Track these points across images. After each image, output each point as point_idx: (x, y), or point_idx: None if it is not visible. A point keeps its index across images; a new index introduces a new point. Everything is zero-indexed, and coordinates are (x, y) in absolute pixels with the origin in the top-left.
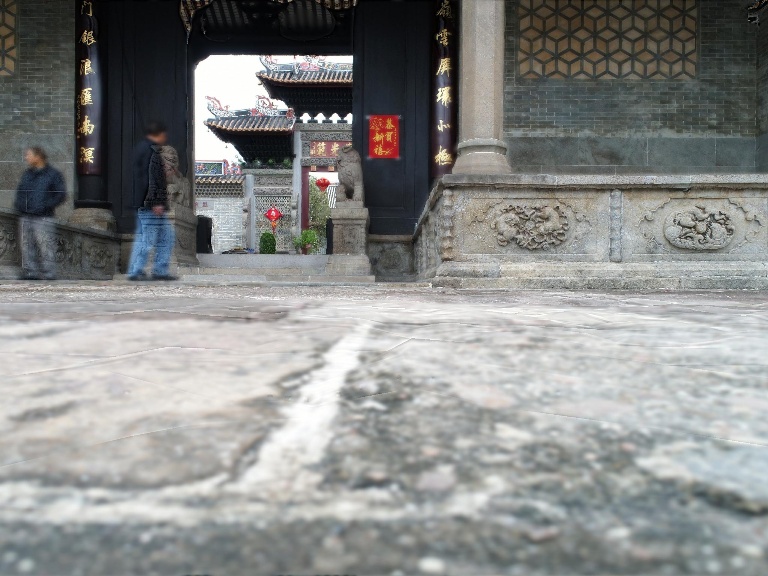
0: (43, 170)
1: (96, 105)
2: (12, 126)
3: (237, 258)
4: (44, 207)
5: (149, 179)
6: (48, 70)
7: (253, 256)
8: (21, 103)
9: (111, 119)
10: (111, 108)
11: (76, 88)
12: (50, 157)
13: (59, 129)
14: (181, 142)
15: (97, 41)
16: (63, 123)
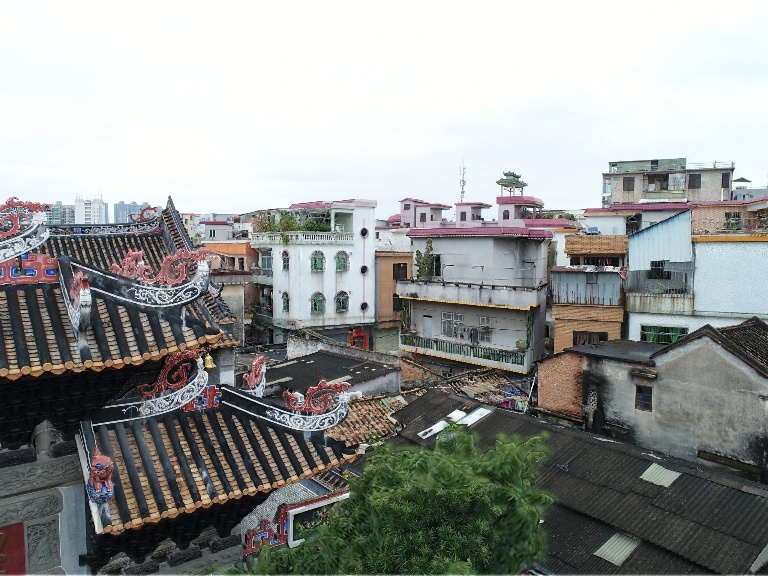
0: None
1: None
2: None
3: None
4: None
5: None
6: None
7: None
8: None
9: None
10: None
11: None
12: None
13: None
14: None
15: None
16: None
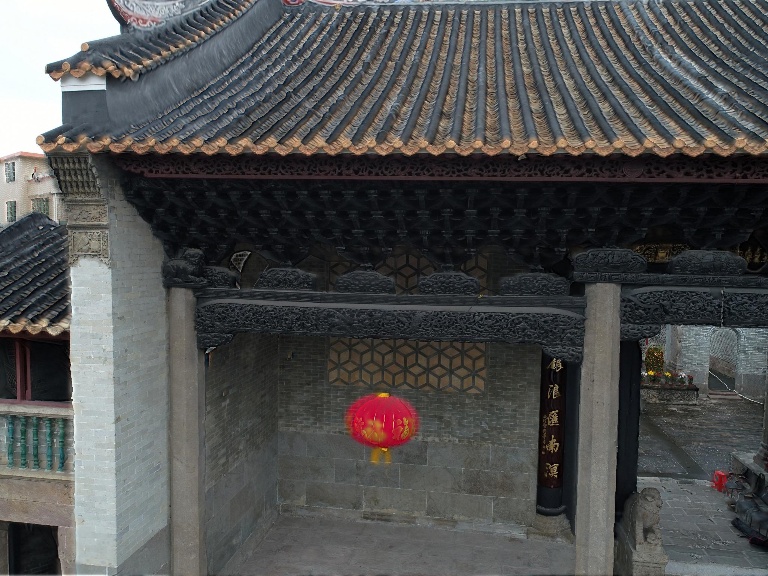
0: (508, 479)
1: (561, 424)
2: (480, 438)
3: (687, 567)
4: (509, 512)
5: (636, 520)
6: (515, 390)
7: (704, 566)
8: (489, 418)
9: (568, 431)
10: (568, 421)
11: (540, 407)
12: (515, 468)
13: (524, 443)
14: (634, 455)
15: (563, 365)
16: (528, 438)
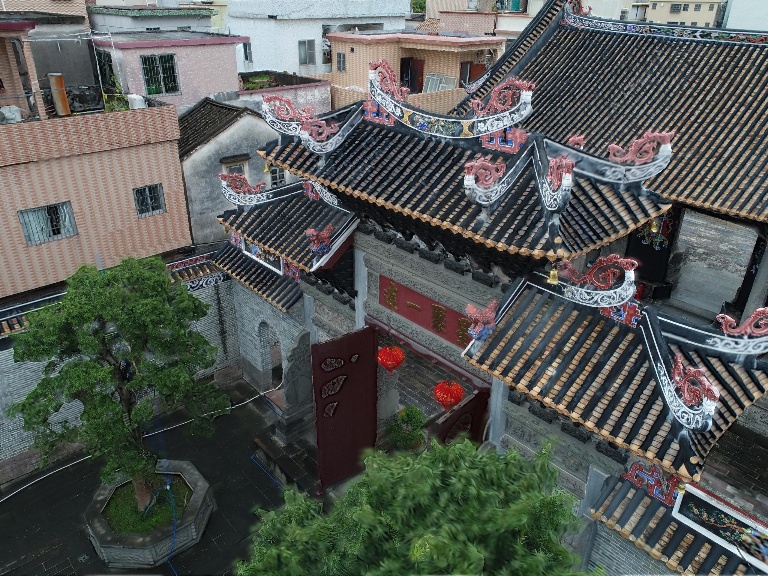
0: None
1: None
2: None
3: None
4: None
5: None
6: None
7: None
8: None
9: None
10: None
11: None
12: None
13: None
14: None
15: None
16: None
